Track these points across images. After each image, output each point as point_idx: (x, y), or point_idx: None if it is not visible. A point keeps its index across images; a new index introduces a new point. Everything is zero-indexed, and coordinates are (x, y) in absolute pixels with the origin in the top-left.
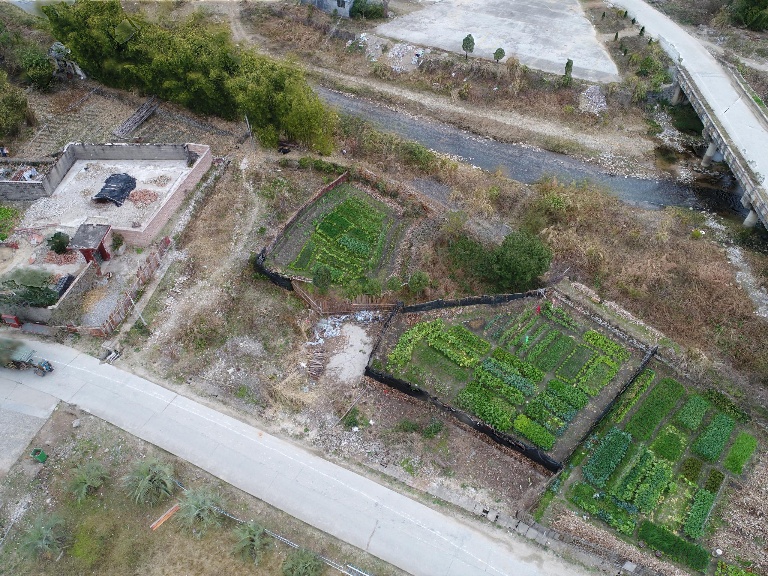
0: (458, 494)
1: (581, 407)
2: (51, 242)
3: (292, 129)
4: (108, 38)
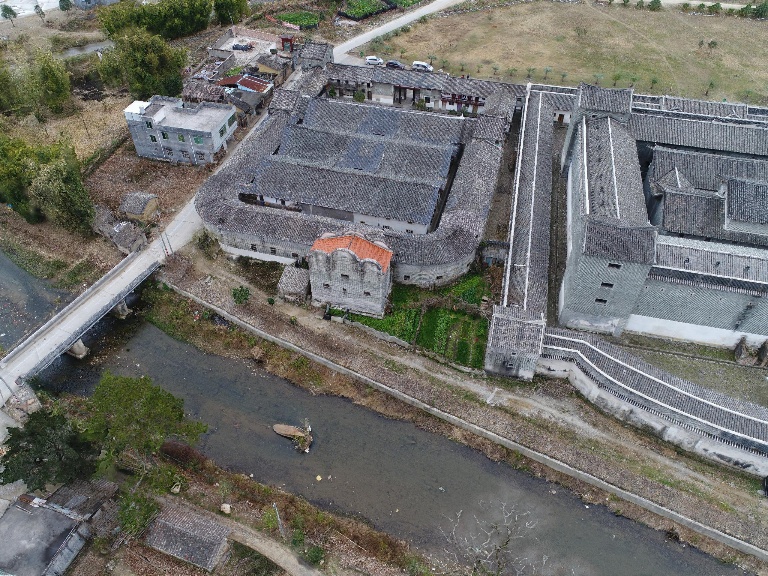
0: (397, 15)
1: (381, 3)
2: (274, 51)
3: (243, 8)
4: (154, 16)
